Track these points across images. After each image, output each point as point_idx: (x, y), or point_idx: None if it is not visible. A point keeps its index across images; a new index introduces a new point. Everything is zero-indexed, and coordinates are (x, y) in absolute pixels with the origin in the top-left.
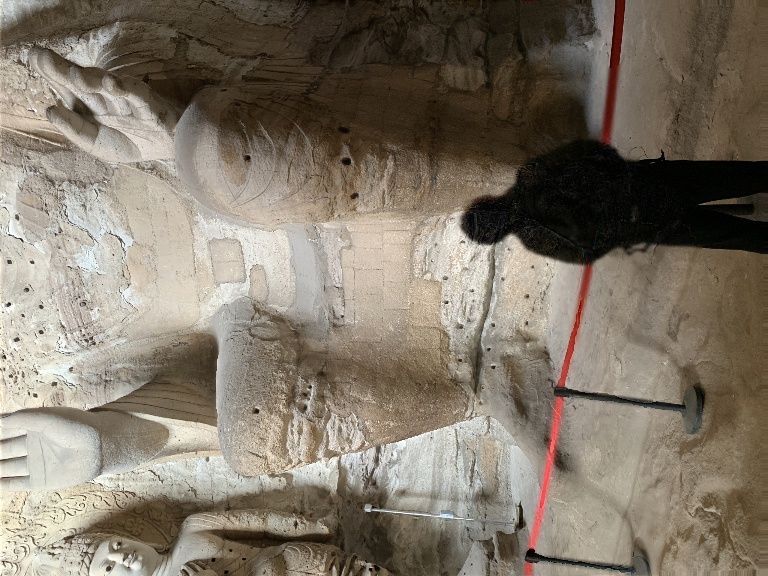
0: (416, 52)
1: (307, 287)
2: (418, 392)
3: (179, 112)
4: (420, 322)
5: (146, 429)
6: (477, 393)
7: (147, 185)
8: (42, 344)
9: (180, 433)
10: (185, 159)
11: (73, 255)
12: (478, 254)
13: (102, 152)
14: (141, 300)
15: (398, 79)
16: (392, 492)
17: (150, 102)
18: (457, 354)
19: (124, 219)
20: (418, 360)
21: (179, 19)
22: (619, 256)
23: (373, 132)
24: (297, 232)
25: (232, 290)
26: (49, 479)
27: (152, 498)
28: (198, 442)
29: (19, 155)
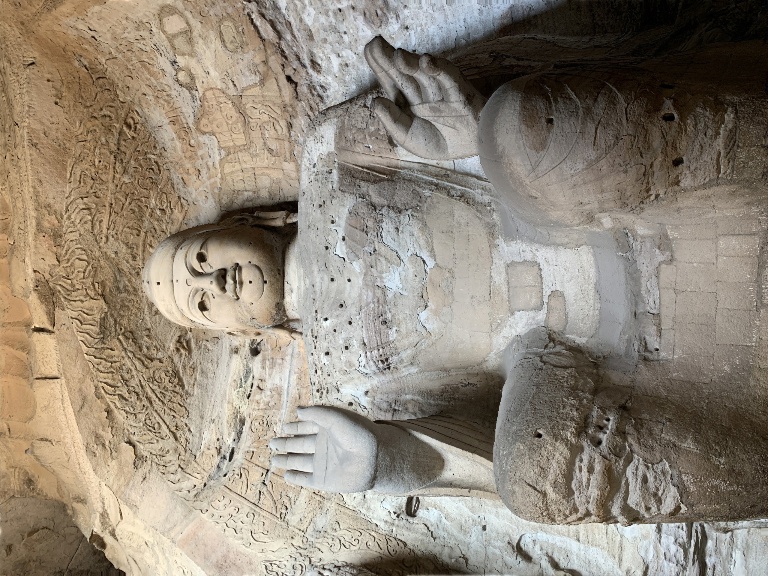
0: None
1: (613, 315)
2: (767, 450)
3: None
4: None
5: (422, 452)
6: None
7: (454, 211)
8: (346, 360)
9: (455, 466)
10: (486, 129)
11: (382, 274)
12: None
13: (413, 143)
14: (435, 324)
15: (743, 46)
16: None
17: (460, 83)
18: None
19: (430, 242)
20: (767, 411)
21: (500, 49)
22: None
23: (706, 86)
24: (605, 246)
25: (527, 319)
26: (328, 478)
27: (422, 554)
28: (473, 480)
29: (353, 184)
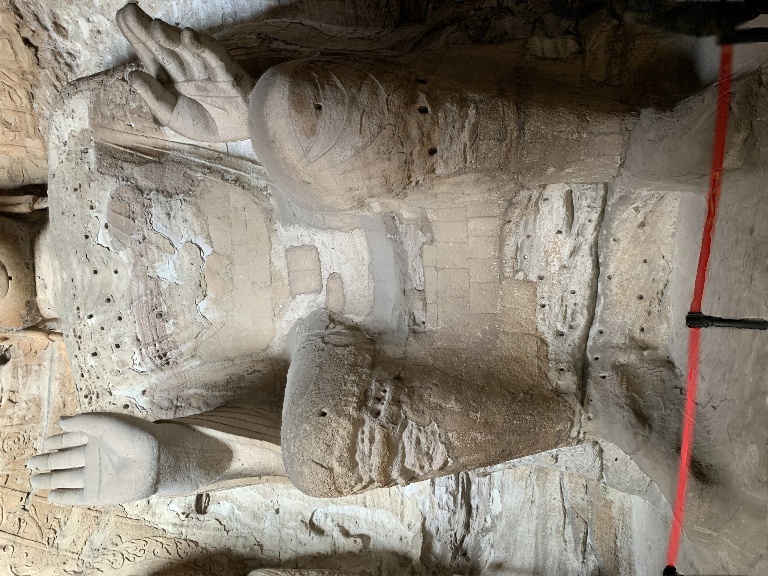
0: (501, 36)
1: (386, 293)
2: (511, 401)
3: (256, 82)
4: (512, 328)
5: (208, 446)
6: (584, 406)
7: (230, 195)
8: (117, 360)
9: (244, 456)
10: (256, 112)
11: (154, 264)
12: (578, 248)
13: (180, 123)
14: (216, 314)
15: (481, 50)
16: (486, 565)
17: (226, 62)
18: (558, 363)
19: (205, 228)
20: (511, 368)
21: (268, 31)
22: (759, 168)
23: (453, 83)
24: (375, 229)
25: (308, 302)
26: (103, 491)
27: (215, 550)
28: (262, 467)
29: (114, 166)
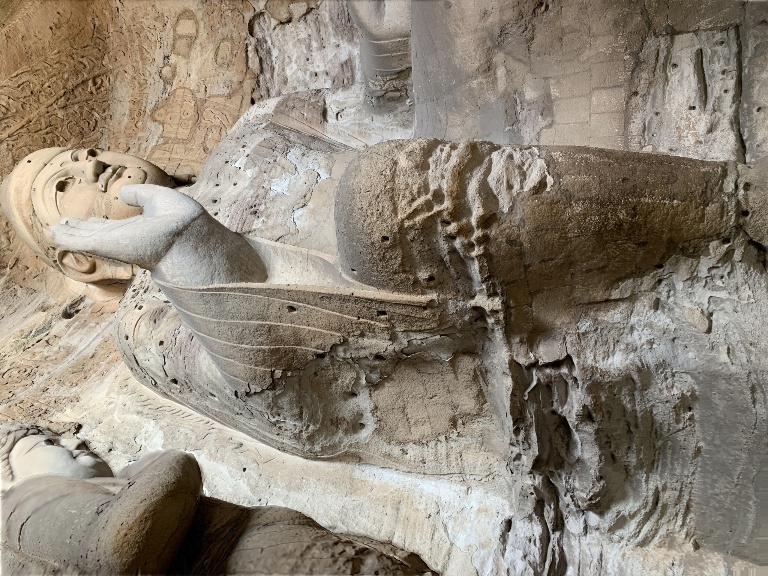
0: None
1: None
2: None
3: None
4: None
5: (247, 252)
6: None
7: None
8: None
9: (279, 280)
10: None
11: (272, 179)
12: (716, 125)
13: None
14: (307, 222)
15: None
16: None
17: None
18: None
19: (330, 165)
20: None
21: None
22: None
23: None
24: (494, 129)
25: None
26: None
27: None
28: None
29: None
